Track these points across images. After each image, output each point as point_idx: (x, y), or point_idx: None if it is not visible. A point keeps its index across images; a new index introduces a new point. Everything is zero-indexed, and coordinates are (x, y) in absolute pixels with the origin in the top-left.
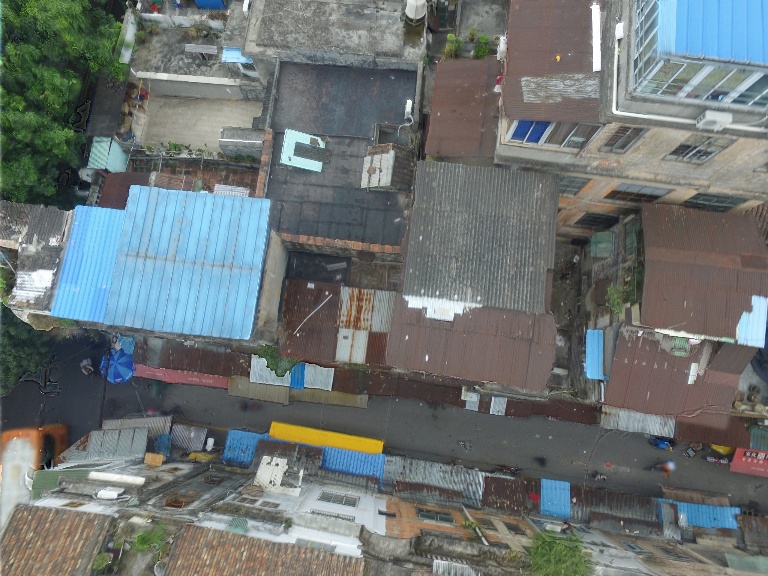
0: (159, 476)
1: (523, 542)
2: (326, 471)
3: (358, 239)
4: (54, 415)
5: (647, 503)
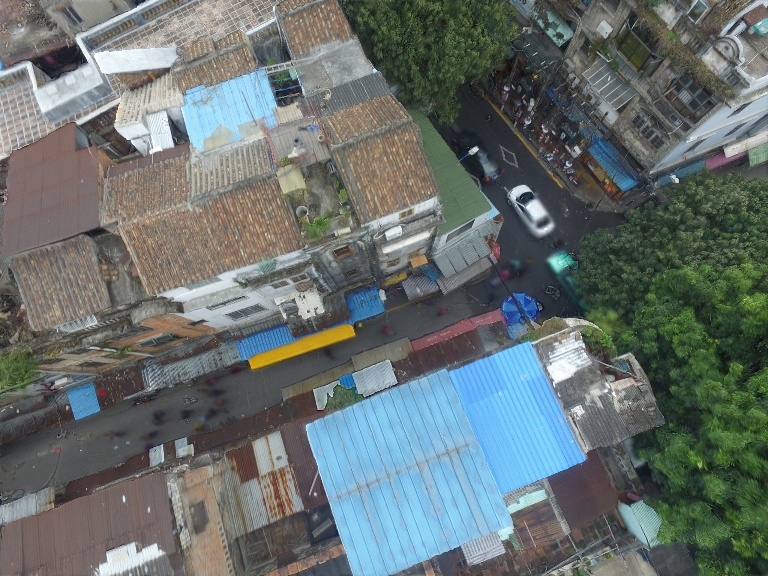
0: (392, 256)
1: (71, 361)
2: (281, 324)
3: (304, 575)
4: (547, 243)
5: (4, 438)
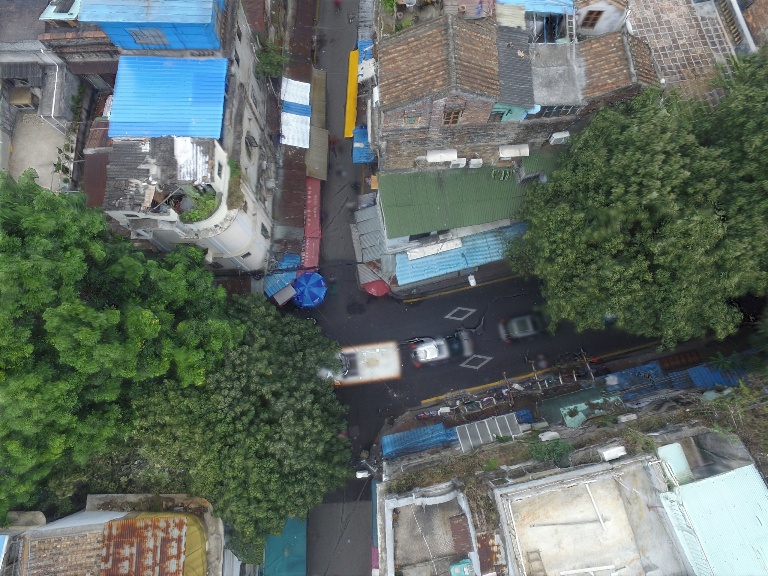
0: None
1: None
2: None
3: None
4: None
5: None
